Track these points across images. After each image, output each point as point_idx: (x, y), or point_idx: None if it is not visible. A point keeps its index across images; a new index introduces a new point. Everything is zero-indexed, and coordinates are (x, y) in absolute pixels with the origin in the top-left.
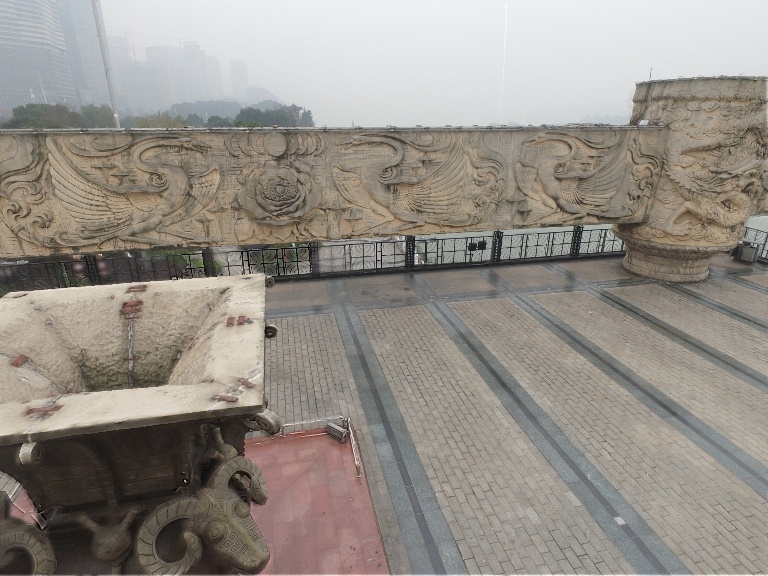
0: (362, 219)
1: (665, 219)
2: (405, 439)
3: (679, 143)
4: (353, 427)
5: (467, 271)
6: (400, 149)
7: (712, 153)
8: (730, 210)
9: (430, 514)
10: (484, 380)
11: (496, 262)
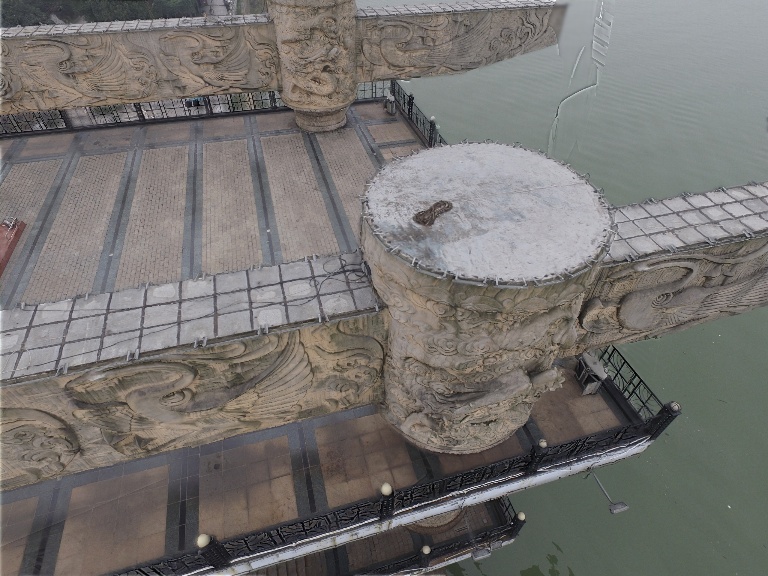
0: (59, 97)
1: (288, 89)
2: (48, 227)
3: (279, 35)
4: (22, 222)
5: (184, 123)
6: (65, 49)
7: (296, 44)
8: (320, 84)
9: (34, 254)
10: (115, 199)
11: (210, 115)
